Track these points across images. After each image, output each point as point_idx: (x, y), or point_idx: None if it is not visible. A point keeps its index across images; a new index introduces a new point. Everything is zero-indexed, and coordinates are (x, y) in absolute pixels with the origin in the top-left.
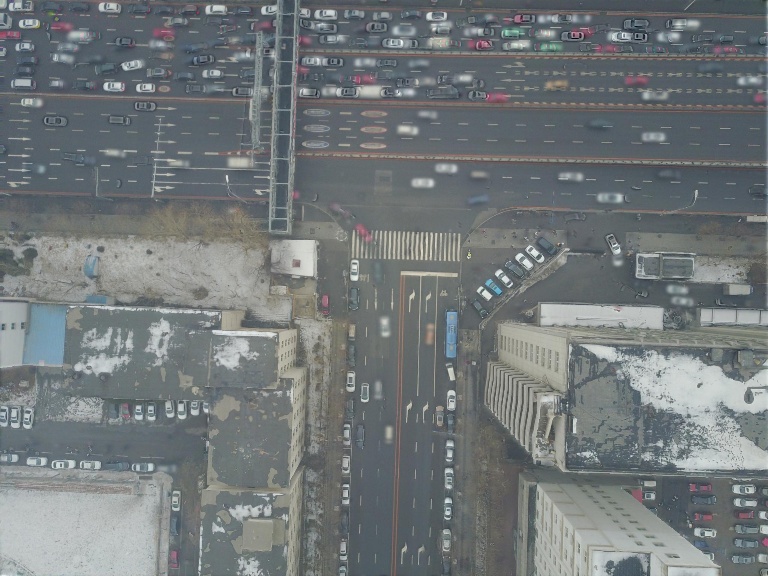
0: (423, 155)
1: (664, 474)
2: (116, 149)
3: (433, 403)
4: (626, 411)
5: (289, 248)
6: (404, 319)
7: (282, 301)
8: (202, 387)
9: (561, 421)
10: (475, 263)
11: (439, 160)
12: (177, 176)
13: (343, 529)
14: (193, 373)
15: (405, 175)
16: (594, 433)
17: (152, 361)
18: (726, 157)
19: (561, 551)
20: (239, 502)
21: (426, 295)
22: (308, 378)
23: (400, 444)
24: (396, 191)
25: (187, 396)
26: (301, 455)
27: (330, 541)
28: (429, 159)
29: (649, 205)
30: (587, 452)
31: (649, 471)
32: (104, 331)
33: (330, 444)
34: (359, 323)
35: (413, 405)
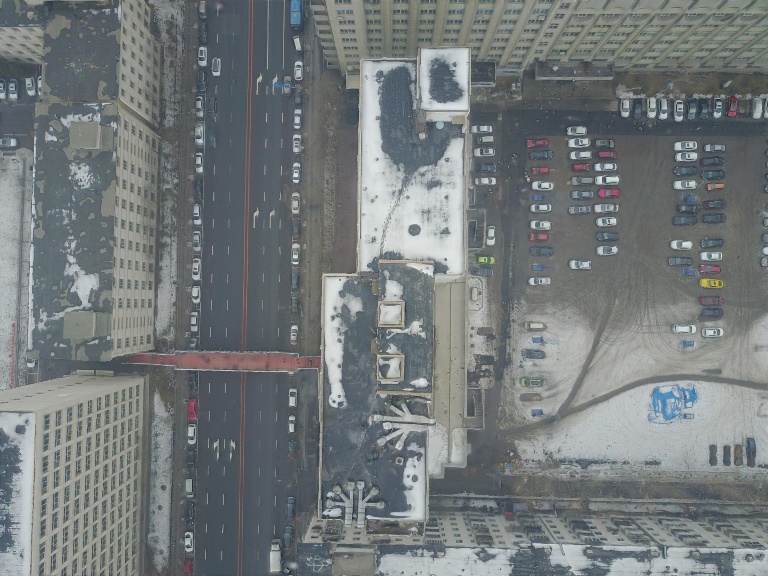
0: None
1: None
2: None
3: (281, 74)
4: None
5: None
6: None
7: None
8: (37, 12)
9: None
10: None
11: None
12: None
13: (197, 195)
14: None
15: None
16: None
17: None
18: None
19: None
20: (70, 112)
21: None
22: (162, 55)
23: (251, 115)
24: None
25: (23, 21)
26: (153, 120)
27: (185, 208)
28: None
29: None
30: None
31: None
32: None
33: (184, 117)
34: (211, 3)
35: (263, 78)
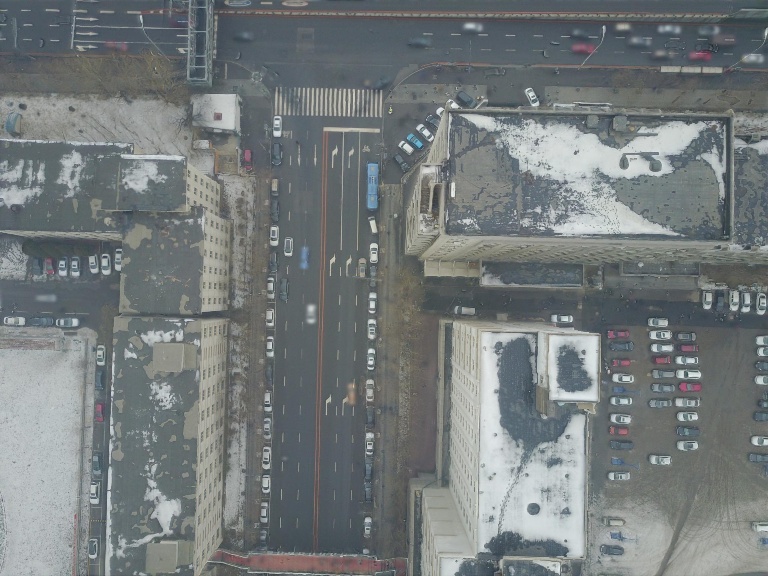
0: (344, 11)
1: (541, 237)
2: (38, 8)
3: (356, 256)
4: (505, 178)
5: (210, 102)
6: (327, 175)
7: (205, 157)
8: (114, 218)
9: (442, 189)
10: (397, 119)
11: (360, 17)
12: (100, 35)
13: (267, 381)
14: (102, 197)
15: (327, 32)
16: (474, 201)
17: (64, 192)
18: (641, 9)
19: (464, 360)
20: (151, 328)
21: (349, 151)
22: (232, 233)
23: (324, 297)
24: (318, 48)
25: (99, 227)
26: (224, 306)
27: (255, 393)
28: (350, 16)
29: (567, 60)
30: (467, 219)
31: (527, 235)
32: (16, 163)
33: (254, 298)
34: (282, 179)
35: (336, 259)
